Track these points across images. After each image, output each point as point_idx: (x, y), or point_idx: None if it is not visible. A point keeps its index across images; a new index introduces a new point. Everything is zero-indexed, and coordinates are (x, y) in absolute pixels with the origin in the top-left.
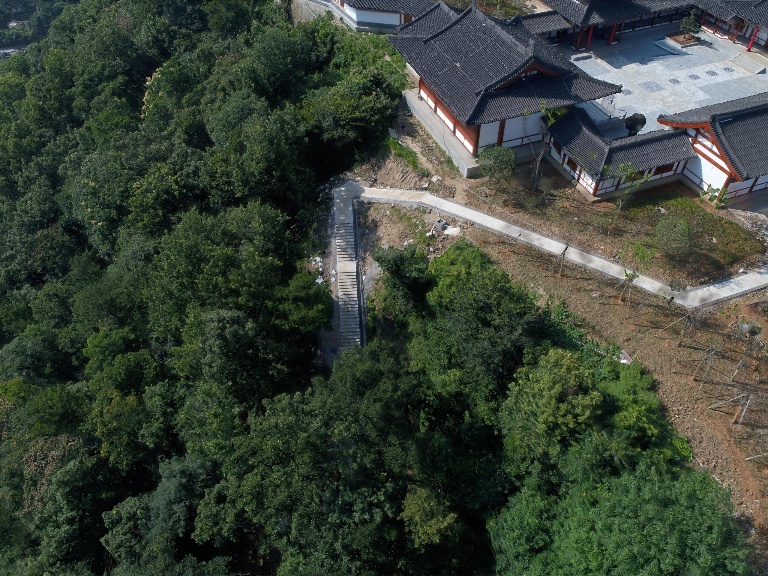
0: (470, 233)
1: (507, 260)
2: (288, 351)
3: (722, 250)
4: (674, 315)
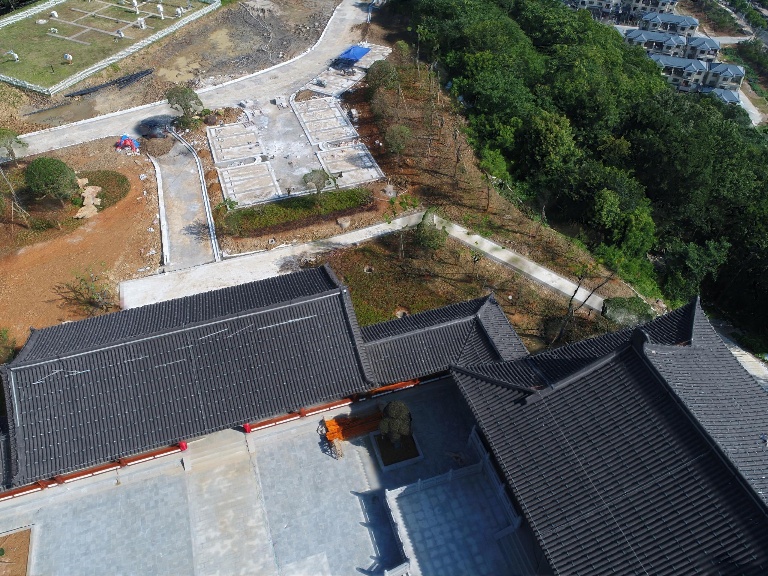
0: (630, 294)
1: (586, 259)
2: (759, 263)
3: (370, 252)
4: (448, 196)
